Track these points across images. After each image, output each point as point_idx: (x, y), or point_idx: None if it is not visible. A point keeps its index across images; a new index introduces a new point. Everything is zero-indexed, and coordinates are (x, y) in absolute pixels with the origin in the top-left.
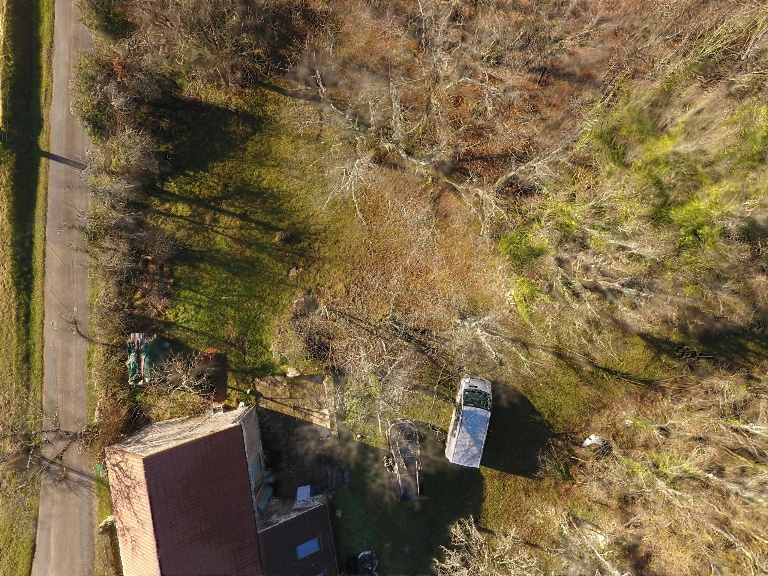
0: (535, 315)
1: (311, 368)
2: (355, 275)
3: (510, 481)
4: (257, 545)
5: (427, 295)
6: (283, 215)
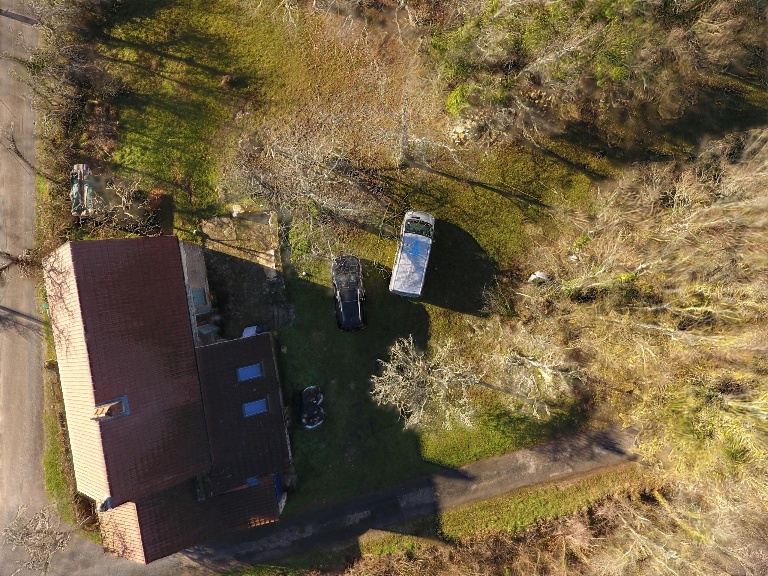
0: (480, 154)
1: (256, 205)
2: (301, 117)
3: (455, 319)
4: (194, 356)
5: (372, 136)
6: (229, 60)
